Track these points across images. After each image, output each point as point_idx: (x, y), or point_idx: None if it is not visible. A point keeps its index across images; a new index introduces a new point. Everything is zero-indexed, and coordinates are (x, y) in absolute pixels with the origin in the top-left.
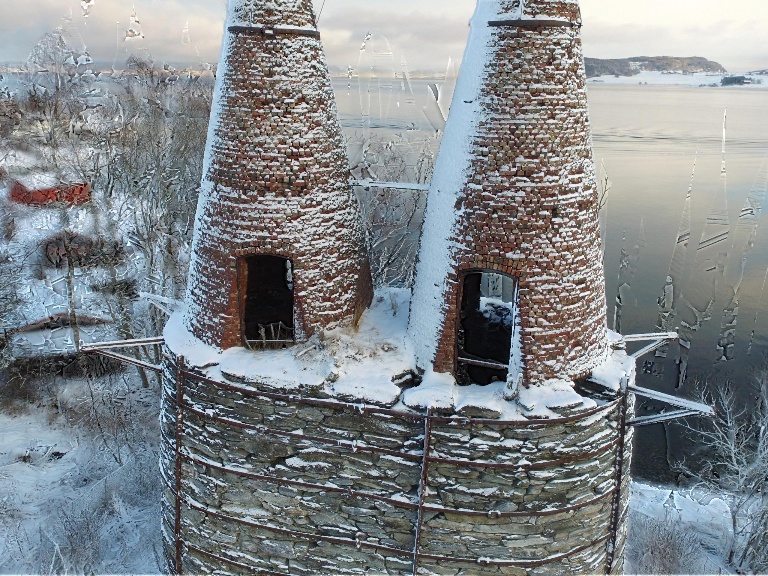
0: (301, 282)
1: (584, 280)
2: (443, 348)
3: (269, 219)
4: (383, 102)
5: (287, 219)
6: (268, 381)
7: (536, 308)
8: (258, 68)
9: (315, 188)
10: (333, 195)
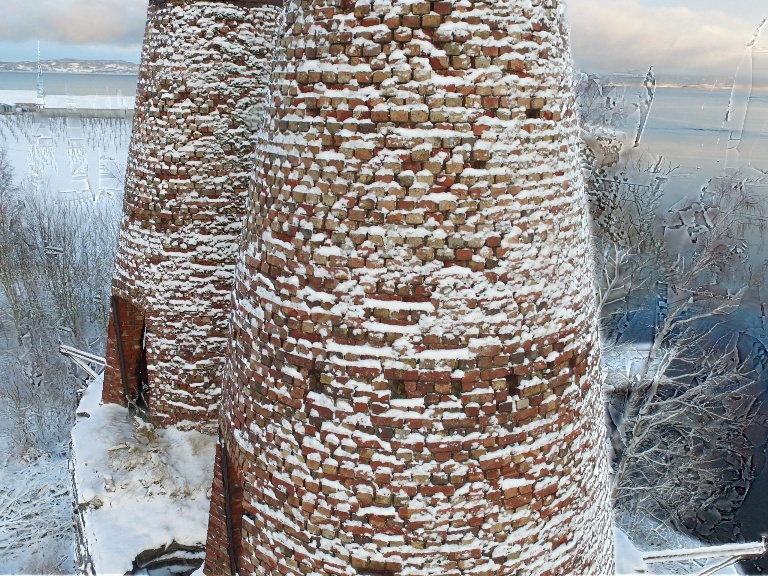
0: (151, 351)
1: (392, 568)
2: (213, 543)
3: (132, 256)
4: (754, 121)
5: (146, 261)
6: (75, 465)
7: (261, 572)
8: (148, 49)
9: (188, 225)
10: (221, 240)
